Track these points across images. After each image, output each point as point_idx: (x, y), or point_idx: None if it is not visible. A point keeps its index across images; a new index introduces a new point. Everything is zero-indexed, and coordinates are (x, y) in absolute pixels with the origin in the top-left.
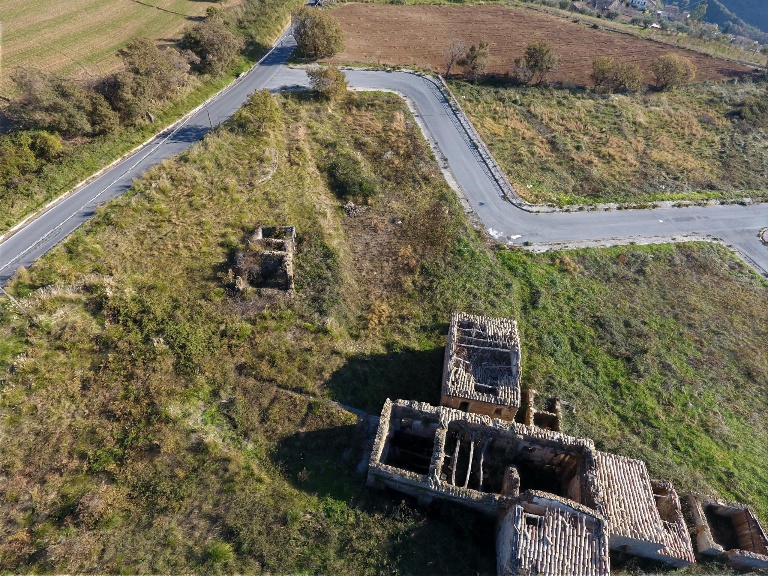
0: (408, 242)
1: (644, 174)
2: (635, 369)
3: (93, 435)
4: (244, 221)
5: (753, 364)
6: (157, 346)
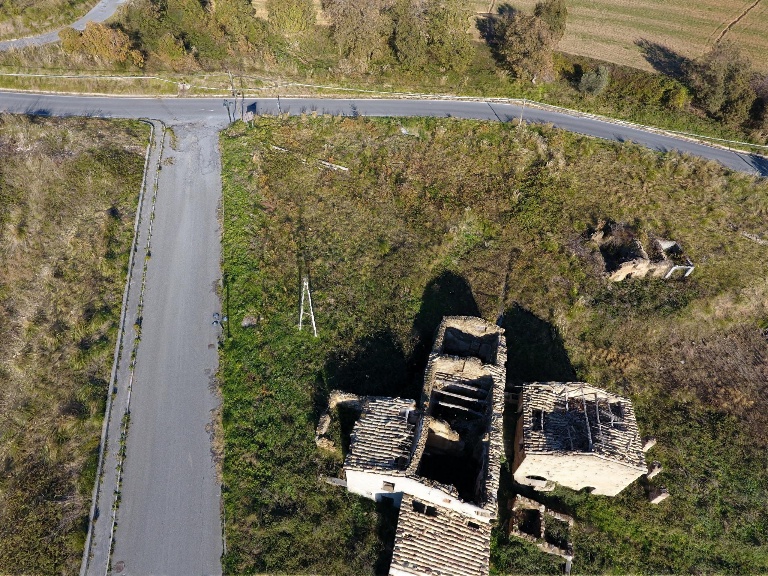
0: (761, 403)
1: None
2: None
3: (447, 185)
4: (678, 232)
5: None
6: (514, 195)
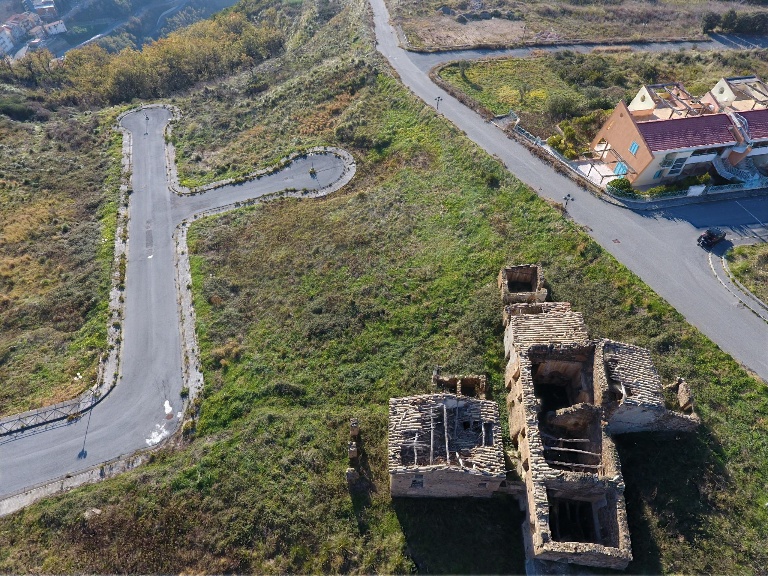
0: None
1: (51, 254)
2: (376, 314)
3: None
4: None
5: (351, 238)
6: None
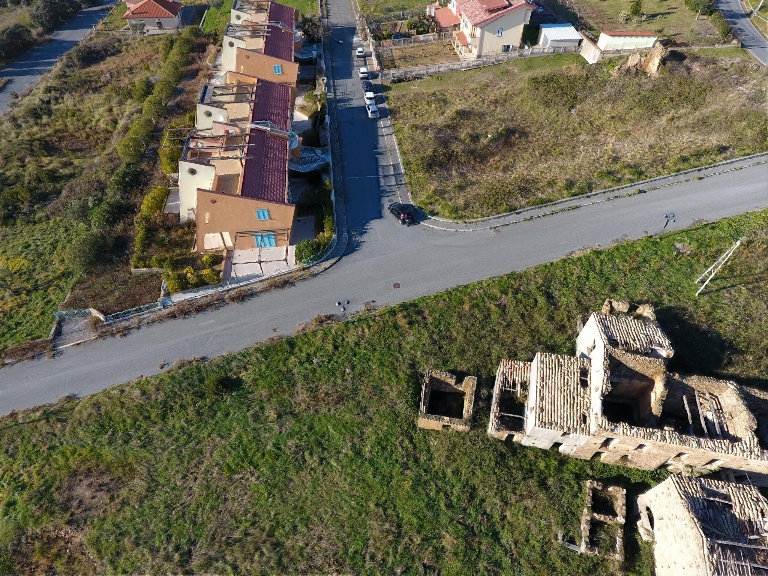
0: None
1: None
2: None
3: None
4: None
5: None
6: None
